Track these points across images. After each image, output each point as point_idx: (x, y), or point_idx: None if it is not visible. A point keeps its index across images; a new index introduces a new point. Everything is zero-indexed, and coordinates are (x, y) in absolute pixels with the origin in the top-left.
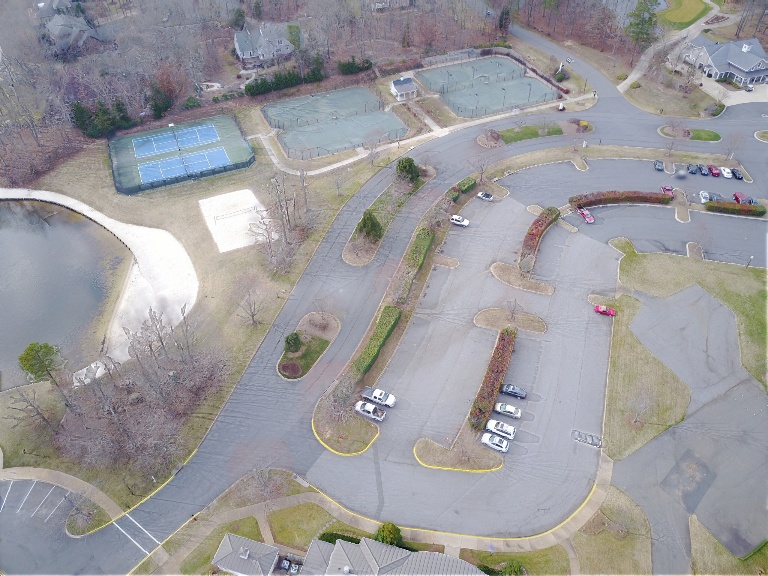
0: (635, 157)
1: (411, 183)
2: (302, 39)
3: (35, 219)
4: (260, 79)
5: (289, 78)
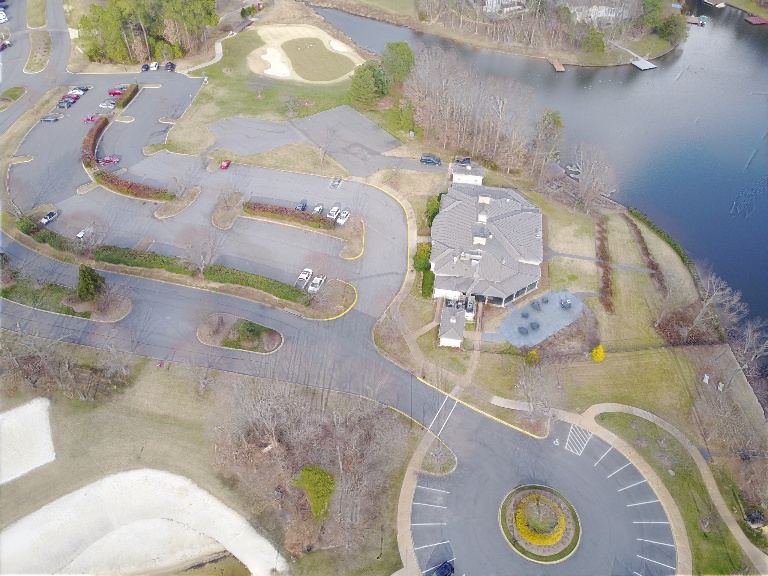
0: (28, 129)
1: None
2: None
3: None
4: None
5: None
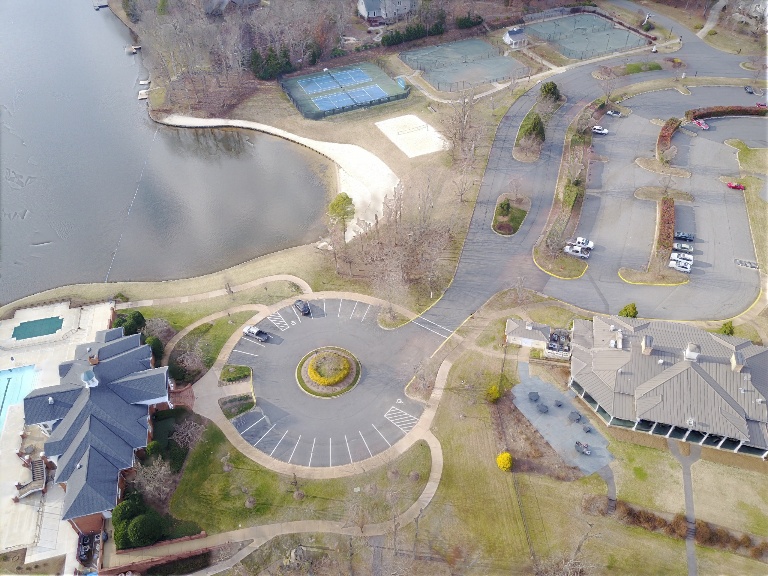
0: (727, 84)
1: (554, 103)
2: (417, 1)
3: (212, 151)
4: (395, 31)
5: (418, 31)
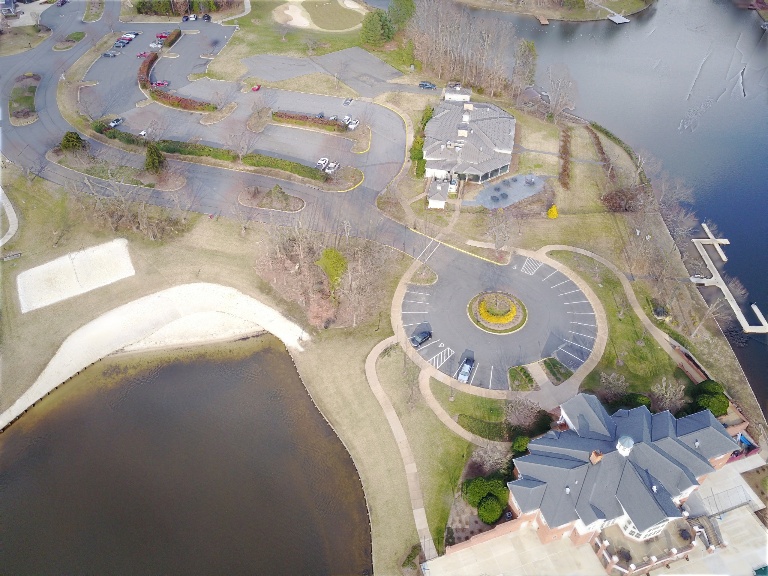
0: (91, 62)
1: None
2: None
3: None
4: None
5: None
